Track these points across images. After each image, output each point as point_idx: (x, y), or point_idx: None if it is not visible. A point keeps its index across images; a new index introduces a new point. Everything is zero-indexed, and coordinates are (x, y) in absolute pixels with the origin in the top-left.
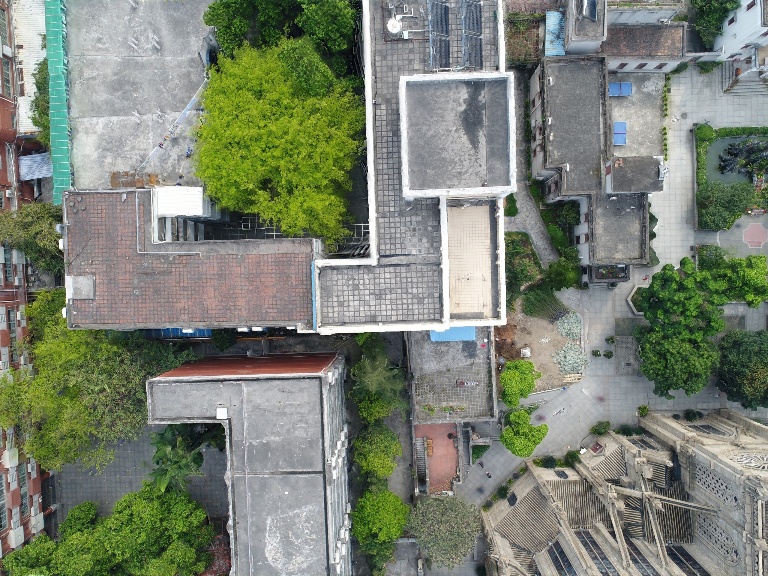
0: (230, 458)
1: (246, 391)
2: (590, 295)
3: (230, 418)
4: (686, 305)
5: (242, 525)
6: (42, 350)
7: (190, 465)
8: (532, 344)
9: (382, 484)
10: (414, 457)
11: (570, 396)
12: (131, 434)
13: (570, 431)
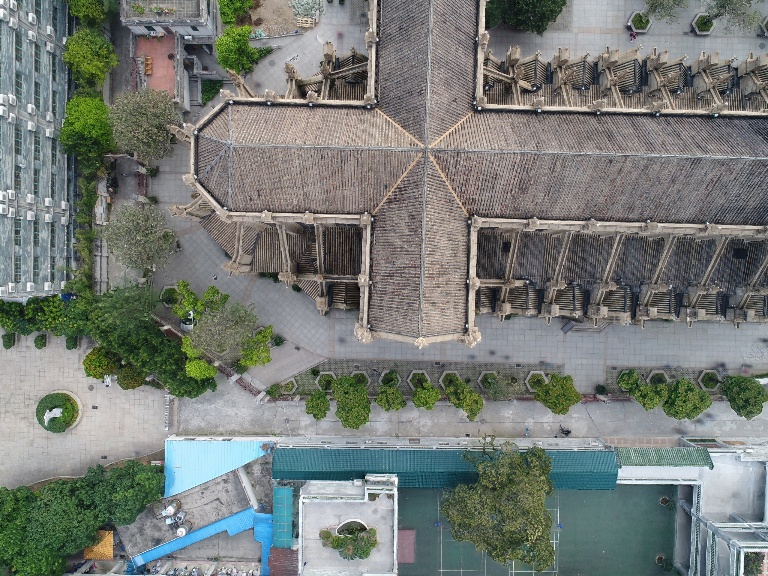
0: None
1: None
2: None
3: None
4: None
5: None
6: None
7: None
8: None
9: (93, 91)
10: (136, 79)
11: (304, 43)
12: None
13: (302, 78)
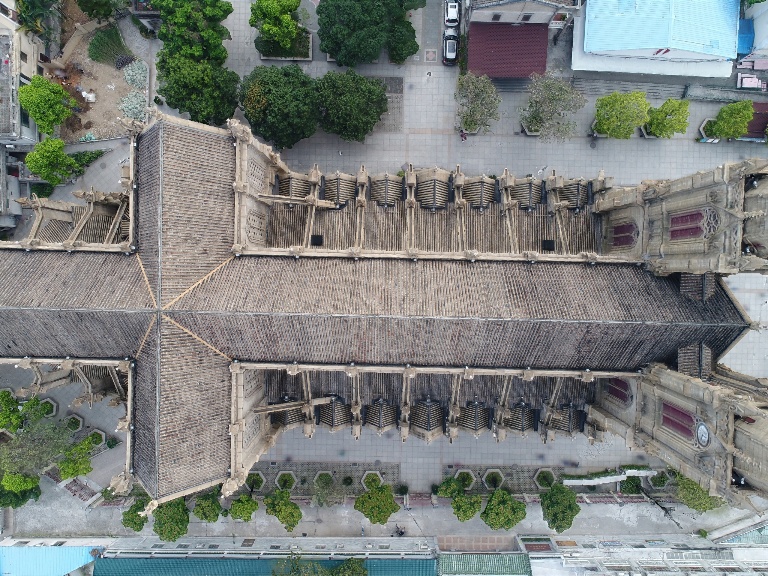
0: None
1: None
2: (159, 45)
3: None
4: (176, 12)
5: None
6: None
7: None
8: (97, 90)
9: None
10: None
11: None
12: None
13: None
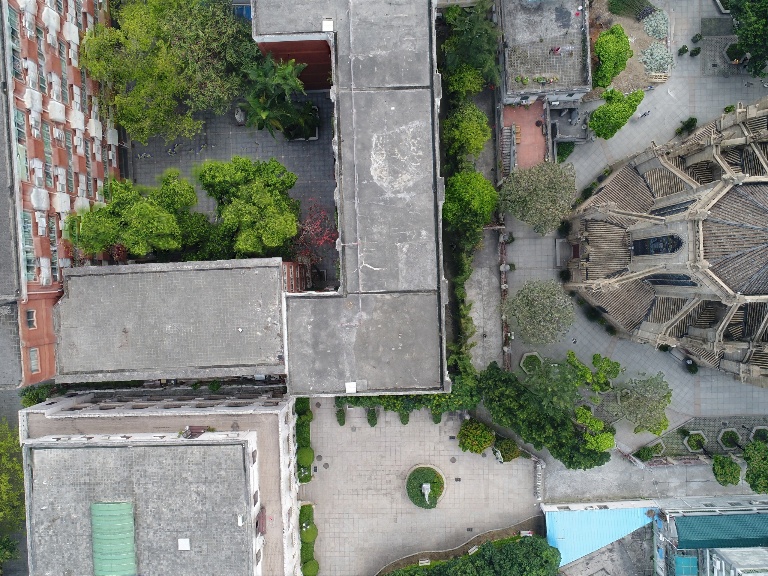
0: (335, 74)
1: (352, 4)
2: None
3: (336, 32)
4: None
5: (347, 143)
6: (132, 5)
7: (295, 79)
8: None
9: None
10: (501, 148)
11: (655, 98)
12: (221, 96)
13: (655, 134)
